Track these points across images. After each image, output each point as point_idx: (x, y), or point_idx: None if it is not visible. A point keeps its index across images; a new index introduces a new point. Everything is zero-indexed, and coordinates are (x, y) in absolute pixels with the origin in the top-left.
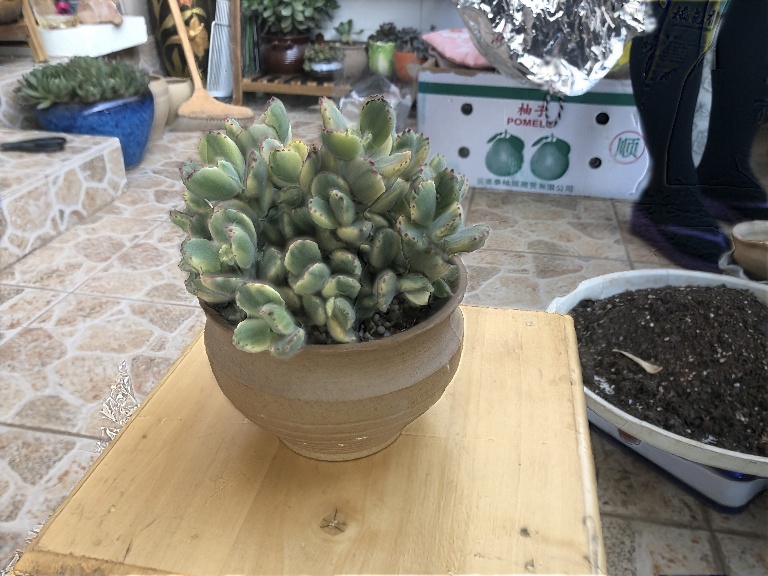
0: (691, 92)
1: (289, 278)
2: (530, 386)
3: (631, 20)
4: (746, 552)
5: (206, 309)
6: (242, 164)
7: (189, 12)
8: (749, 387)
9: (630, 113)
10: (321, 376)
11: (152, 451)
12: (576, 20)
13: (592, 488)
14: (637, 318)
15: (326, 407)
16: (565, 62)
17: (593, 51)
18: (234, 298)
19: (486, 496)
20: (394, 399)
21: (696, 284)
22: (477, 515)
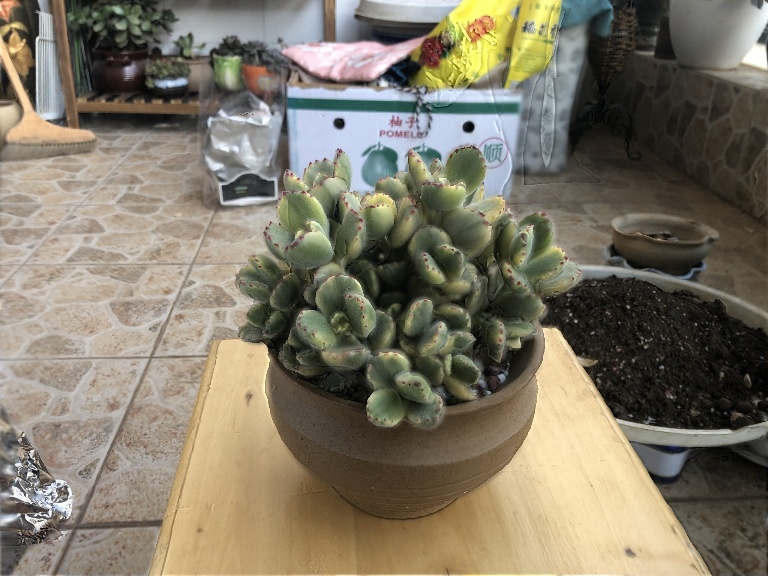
0: (537, 98)
1: (401, 340)
2: (561, 405)
3: (484, 34)
4: (691, 516)
5: (301, 383)
6: (327, 223)
7: (7, 27)
8: (672, 368)
9: (493, 121)
10: (441, 437)
11: (218, 545)
12: (436, 34)
13: (659, 496)
14: (561, 316)
15: (448, 468)
16: (429, 75)
17: (455, 64)
18: (364, 371)
19: (579, 524)
20: (506, 447)
21: (591, 277)
22: (580, 545)
